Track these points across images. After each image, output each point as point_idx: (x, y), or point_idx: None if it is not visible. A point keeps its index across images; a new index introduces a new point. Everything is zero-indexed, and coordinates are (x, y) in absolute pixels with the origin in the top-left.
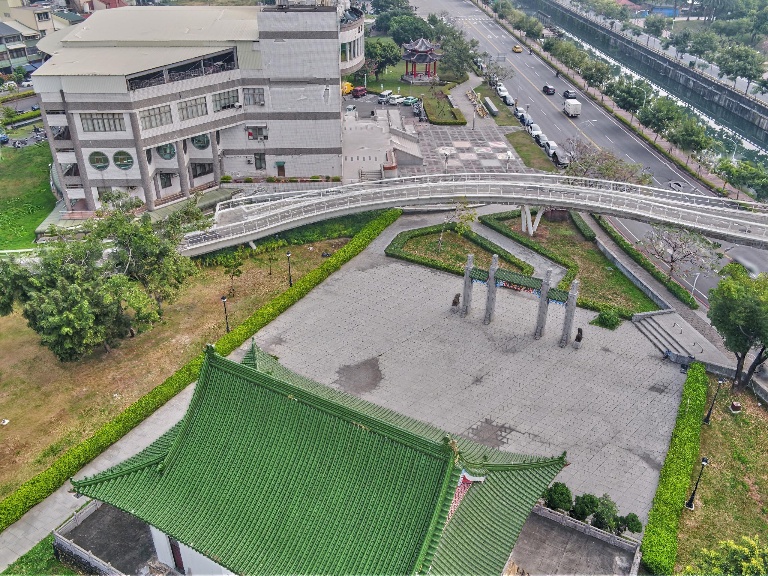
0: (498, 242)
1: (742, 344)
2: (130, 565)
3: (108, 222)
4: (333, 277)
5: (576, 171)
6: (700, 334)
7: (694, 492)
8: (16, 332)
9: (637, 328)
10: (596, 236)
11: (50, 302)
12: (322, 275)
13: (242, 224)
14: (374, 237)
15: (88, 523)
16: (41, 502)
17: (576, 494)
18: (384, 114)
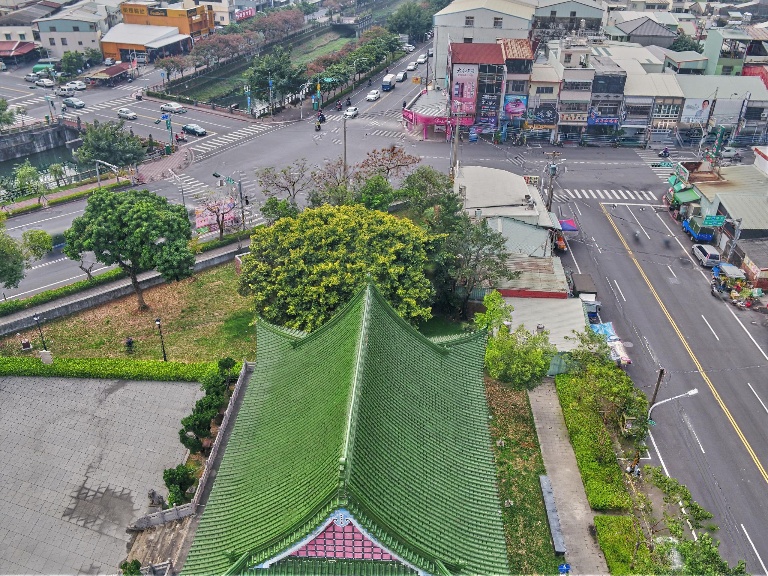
0: None
1: None
2: None
3: None
4: None
5: None
6: None
7: None
8: None
9: None
10: None
11: None
12: None
13: None
14: None
15: None
16: None
17: (174, 425)
18: None
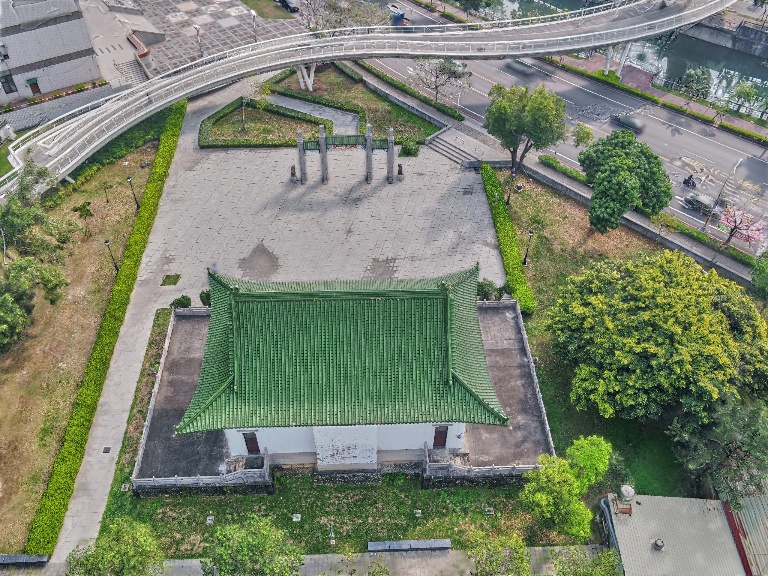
0: (289, 105)
1: (515, 142)
2: (208, 470)
3: None
4: (168, 185)
5: (332, 23)
6: (475, 140)
7: (526, 254)
8: None
9: (432, 149)
10: (363, 77)
11: None
12: (159, 187)
13: (56, 162)
14: (179, 133)
15: (147, 462)
16: (79, 471)
17: None
18: None
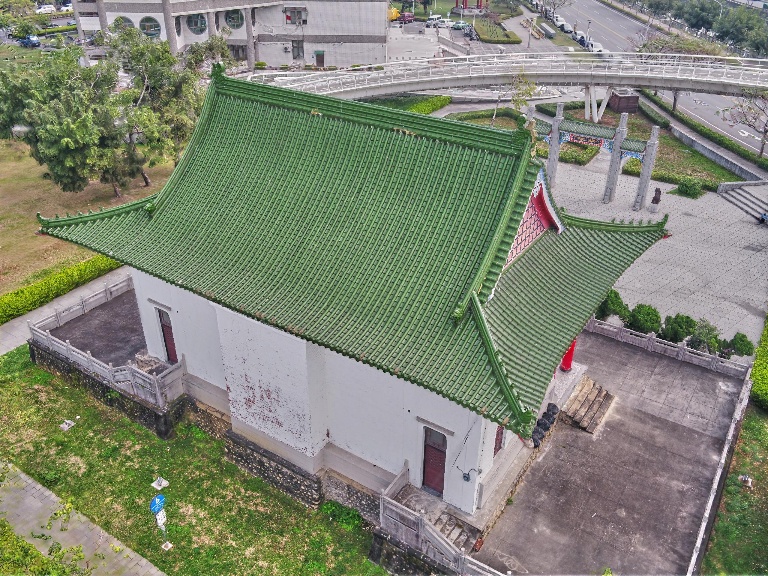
0: None
1: None
2: (115, 362)
3: (121, 38)
4: None
5: (650, 48)
6: None
7: None
8: (21, 178)
9: (724, 198)
10: (670, 123)
11: (51, 112)
12: None
13: None
14: None
15: (72, 325)
16: (24, 314)
17: None
18: (432, 31)
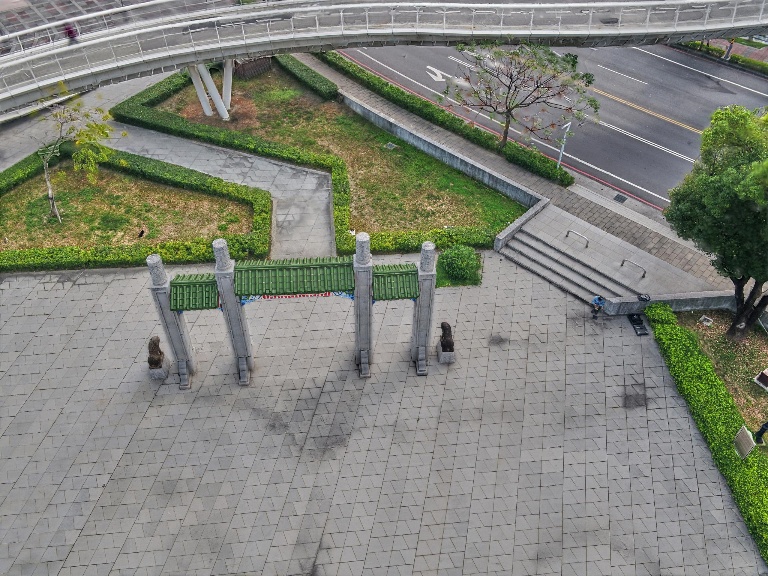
0: (172, 155)
1: None
2: None
3: None
4: None
5: None
6: (613, 236)
7: None
8: None
9: (511, 261)
10: (338, 88)
11: None
12: None
13: None
14: None
15: None
16: None
17: None
18: None
